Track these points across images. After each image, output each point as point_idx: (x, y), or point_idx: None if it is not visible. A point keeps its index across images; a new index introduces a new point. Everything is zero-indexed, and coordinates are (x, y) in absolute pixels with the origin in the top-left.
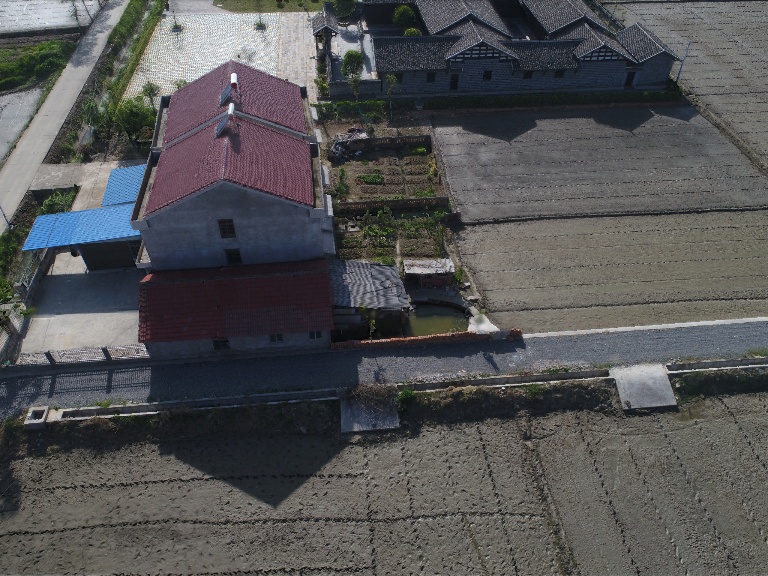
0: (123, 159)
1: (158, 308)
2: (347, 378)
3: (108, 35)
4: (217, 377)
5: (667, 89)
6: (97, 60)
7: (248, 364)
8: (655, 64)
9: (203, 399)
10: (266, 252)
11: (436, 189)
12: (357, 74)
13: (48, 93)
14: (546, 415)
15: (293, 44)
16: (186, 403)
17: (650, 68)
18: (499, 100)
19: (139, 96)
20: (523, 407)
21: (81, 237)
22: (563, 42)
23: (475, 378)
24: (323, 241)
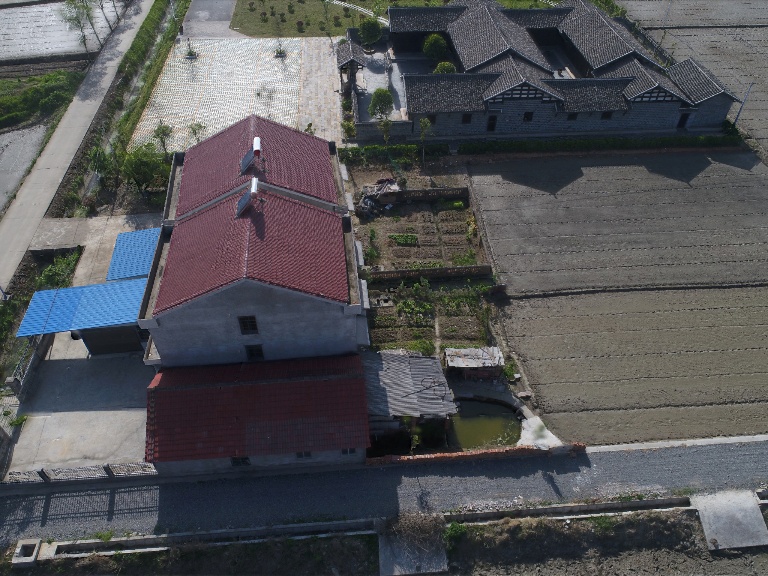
0: (132, 213)
1: (168, 420)
2: (385, 505)
3: (118, 64)
4: (235, 501)
5: (723, 131)
6: (106, 93)
7: (271, 483)
8: (712, 105)
9: (219, 531)
10: (292, 347)
11: (476, 253)
12: (386, 114)
13: (53, 132)
14: (618, 555)
15: (315, 75)
16: (199, 535)
17: (706, 109)
18: (541, 144)
19: (150, 143)
20: (591, 545)
21: (83, 321)
22: (611, 81)
23: (534, 507)
24: None
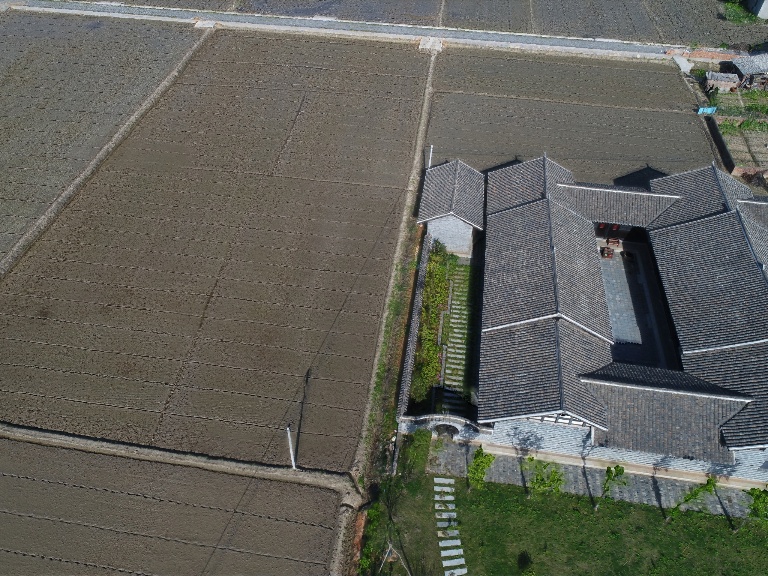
0: None
1: None
2: None
3: None
4: None
5: None
6: None
7: None
8: None
9: None
10: None
11: None
12: None
13: None
14: None
15: None
16: None
17: None
18: None
19: None
20: None
21: None
22: None
23: None
24: None
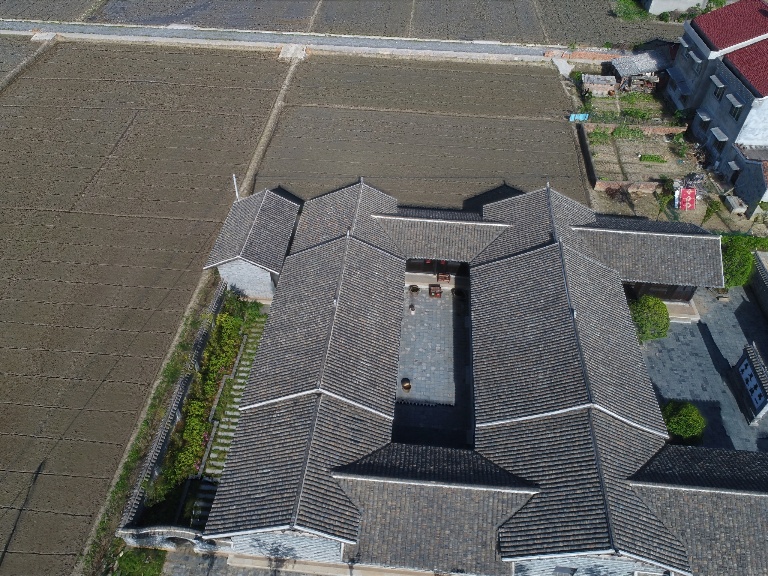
0: None
1: None
2: None
3: None
4: None
5: None
6: None
7: None
8: None
9: None
10: None
11: None
12: None
13: None
14: None
15: None
16: None
17: None
18: None
19: None
20: None
21: None
22: None
23: None
24: (678, 71)
